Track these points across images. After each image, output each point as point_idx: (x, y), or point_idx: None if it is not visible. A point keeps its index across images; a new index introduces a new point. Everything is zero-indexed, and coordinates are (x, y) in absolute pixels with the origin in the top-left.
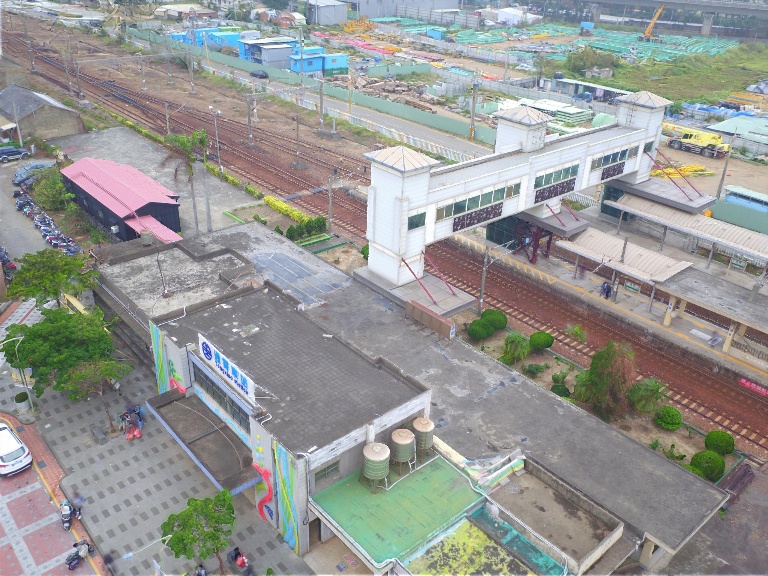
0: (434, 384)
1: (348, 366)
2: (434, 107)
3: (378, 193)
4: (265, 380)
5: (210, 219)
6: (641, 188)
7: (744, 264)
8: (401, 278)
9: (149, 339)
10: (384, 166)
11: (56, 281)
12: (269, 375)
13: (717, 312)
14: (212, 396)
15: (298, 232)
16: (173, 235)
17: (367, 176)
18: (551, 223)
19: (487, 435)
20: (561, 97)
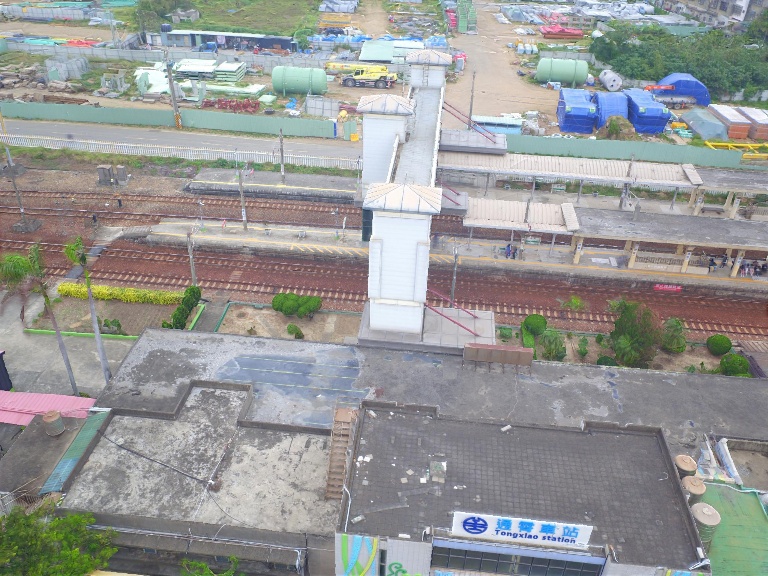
0: (577, 416)
1: (568, 448)
2: (79, 96)
3: (386, 244)
4: (541, 515)
5: (105, 354)
6: (449, 143)
7: (564, 187)
8: (421, 324)
9: (278, 555)
10: (397, 213)
11: (75, 567)
12: (535, 507)
13: (633, 240)
14: (474, 569)
15: (183, 317)
16: (60, 399)
17: (129, 210)
18: (446, 206)
19: (670, 437)
20: (199, 54)
